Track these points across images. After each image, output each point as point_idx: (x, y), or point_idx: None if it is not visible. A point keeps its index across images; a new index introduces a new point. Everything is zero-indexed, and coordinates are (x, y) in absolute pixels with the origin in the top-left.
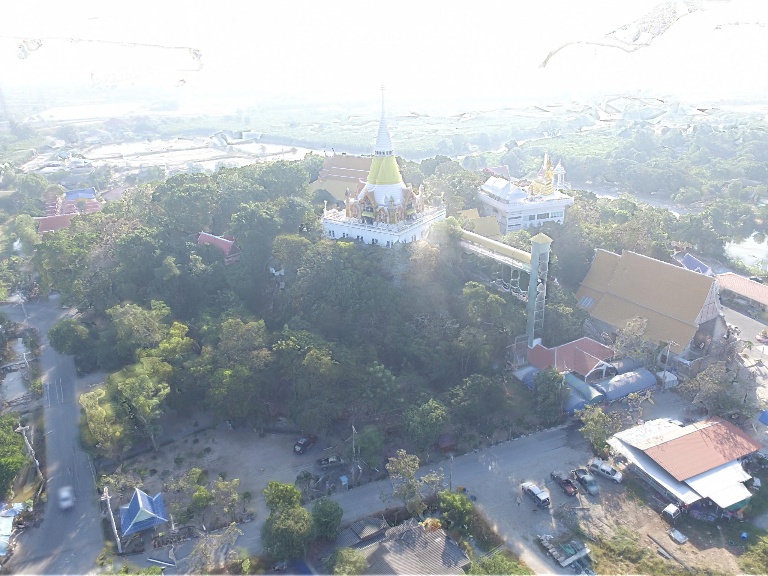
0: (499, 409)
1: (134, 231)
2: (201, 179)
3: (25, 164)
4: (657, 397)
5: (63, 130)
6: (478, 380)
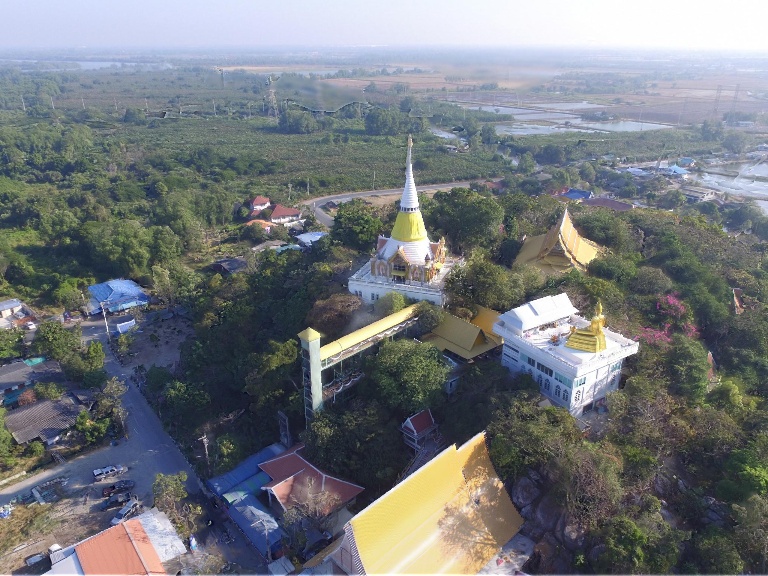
0: (191, 428)
1: (348, 212)
2: (462, 196)
3: (649, 162)
4: (258, 569)
5: (730, 139)
6: (199, 396)
